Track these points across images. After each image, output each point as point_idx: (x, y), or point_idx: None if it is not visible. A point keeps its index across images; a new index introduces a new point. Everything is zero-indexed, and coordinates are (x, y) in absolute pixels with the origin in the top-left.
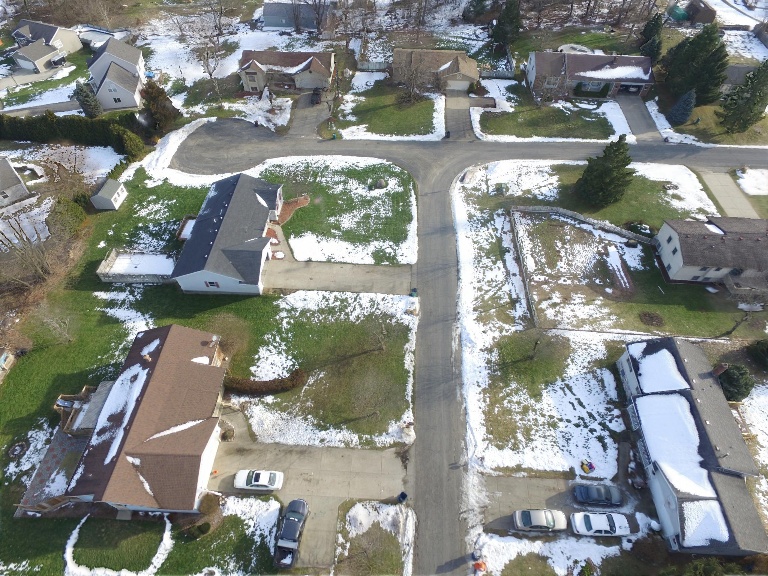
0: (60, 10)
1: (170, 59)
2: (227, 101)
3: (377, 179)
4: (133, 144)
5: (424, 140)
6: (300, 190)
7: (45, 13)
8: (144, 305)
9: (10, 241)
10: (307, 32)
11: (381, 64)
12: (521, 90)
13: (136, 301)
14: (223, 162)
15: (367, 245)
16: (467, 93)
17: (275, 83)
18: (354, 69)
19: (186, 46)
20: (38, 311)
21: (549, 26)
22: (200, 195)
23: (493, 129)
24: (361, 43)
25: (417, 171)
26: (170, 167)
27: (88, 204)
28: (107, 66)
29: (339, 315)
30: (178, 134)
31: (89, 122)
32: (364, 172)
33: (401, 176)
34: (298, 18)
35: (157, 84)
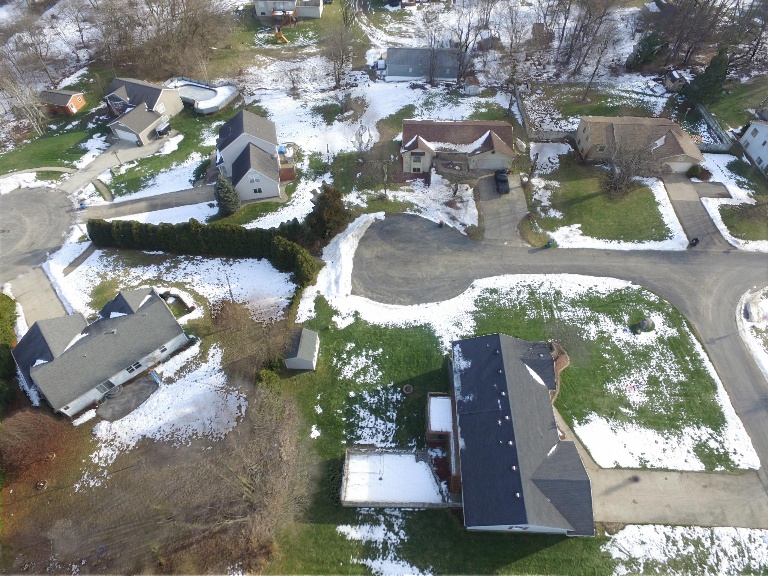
0: (149, 60)
1: (292, 123)
2: (387, 187)
3: (635, 314)
4: (309, 266)
5: (665, 249)
6: (542, 333)
7: (124, 60)
8: (417, 553)
9: (236, 475)
10: (444, 85)
11: (560, 133)
12: (747, 170)
13: (403, 544)
14: (420, 285)
15: (680, 435)
16: (687, 177)
17: (442, 162)
18: (526, 139)
19: (303, 104)
20: (272, 567)
21: (734, 76)
22: (411, 340)
23: (745, 231)
24: (520, 102)
25: (681, 301)
26: (354, 293)
27: (282, 367)
28: (242, 147)
29: (701, 571)
30: (348, 241)
31: (243, 232)
32: (612, 302)
33: (664, 309)
34: (434, 69)
35: (292, 162)
